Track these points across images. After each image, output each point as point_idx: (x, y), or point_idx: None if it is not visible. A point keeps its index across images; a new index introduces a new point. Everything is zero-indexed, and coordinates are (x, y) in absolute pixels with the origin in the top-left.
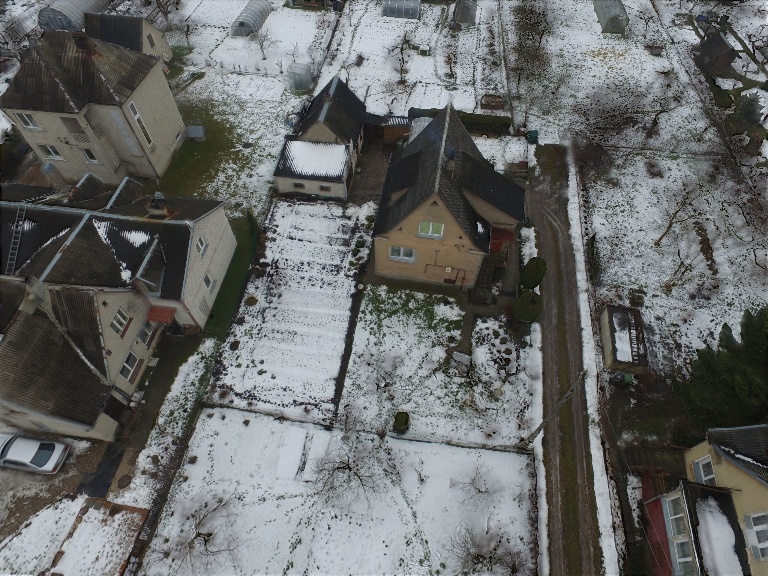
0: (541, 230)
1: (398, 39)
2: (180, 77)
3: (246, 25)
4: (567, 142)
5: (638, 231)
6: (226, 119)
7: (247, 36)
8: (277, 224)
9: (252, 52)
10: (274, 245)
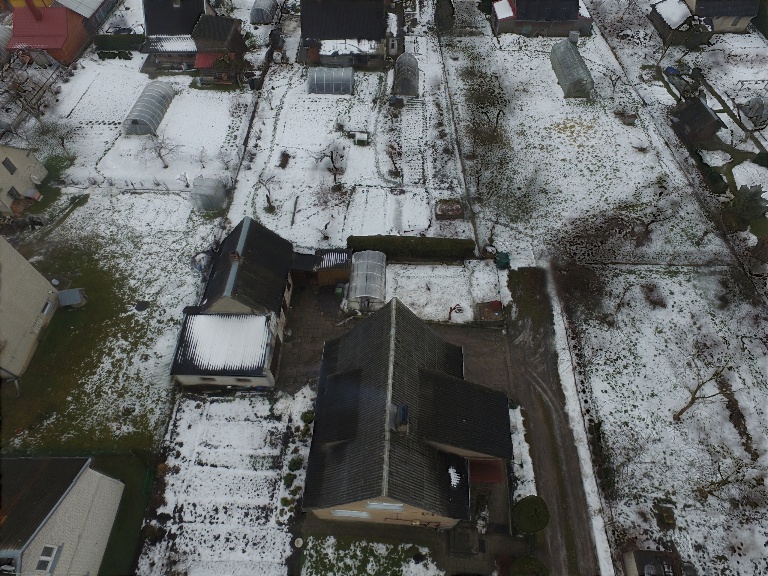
0: (529, 410)
1: (330, 124)
2: (56, 205)
3: (141, 122)
4: (545, 263)
5: (650, 397)
6: (115, 265)
7: (144, 134)
8: (181, 441)
9: (147, 165)
10: (177, 480)
